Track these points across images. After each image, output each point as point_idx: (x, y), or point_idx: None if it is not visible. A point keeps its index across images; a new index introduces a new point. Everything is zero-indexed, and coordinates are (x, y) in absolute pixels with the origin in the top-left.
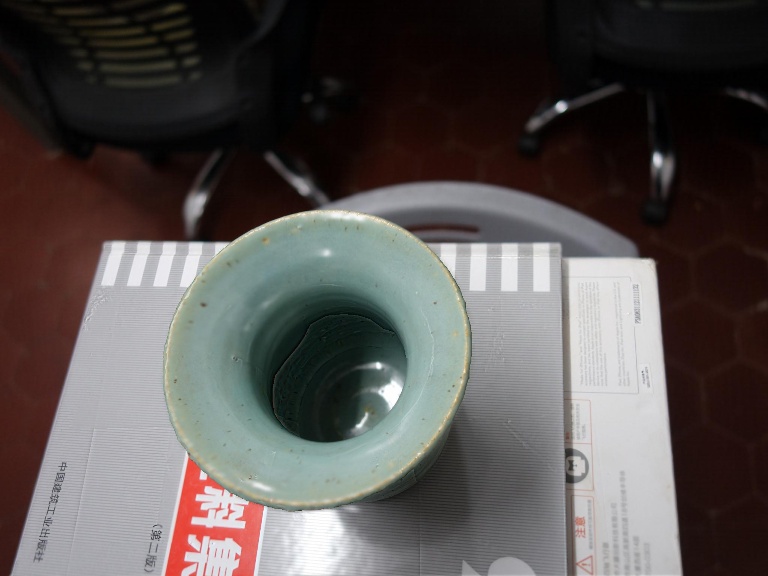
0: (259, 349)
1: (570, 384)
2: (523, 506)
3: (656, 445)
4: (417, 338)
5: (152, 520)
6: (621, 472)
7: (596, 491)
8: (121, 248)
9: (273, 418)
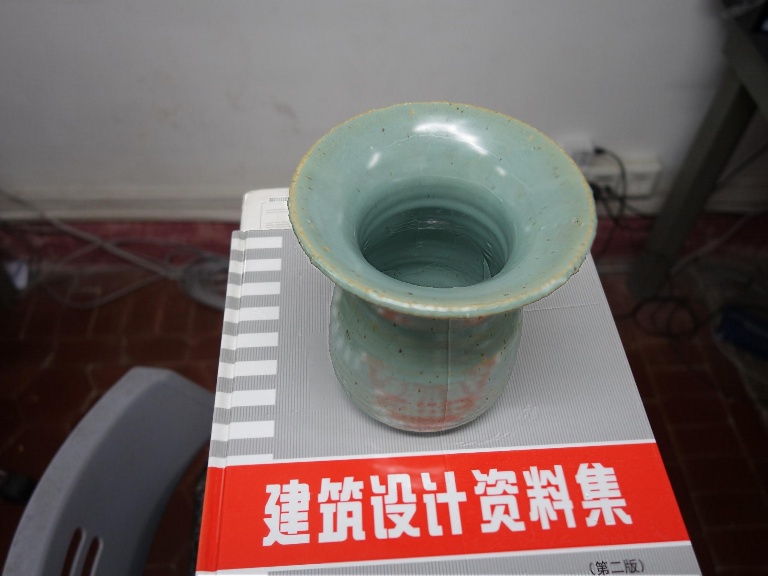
0: None
1: None
2: None
3: None
4: (409, 156)
5: None
6: None
7: None
8: None
9: None
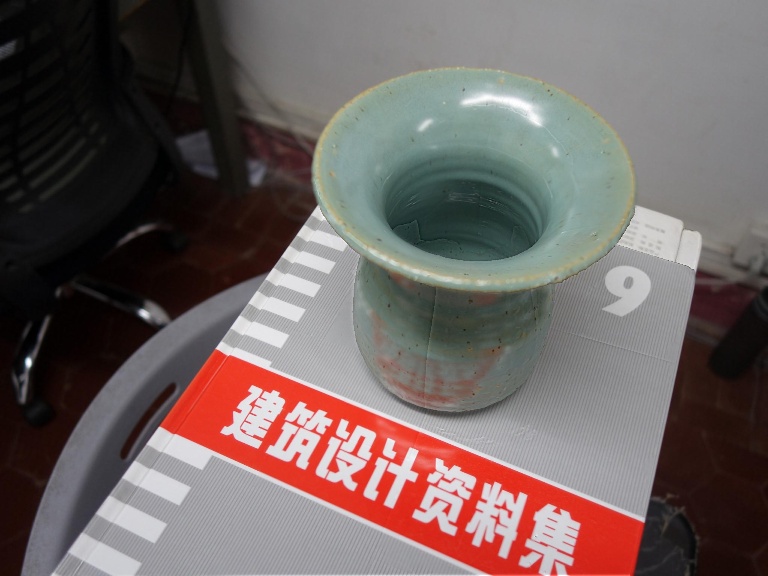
0: None
1: None
2: None
3: None
4: (481, 124)
5: None
6: None
7: None
8: None
9: None
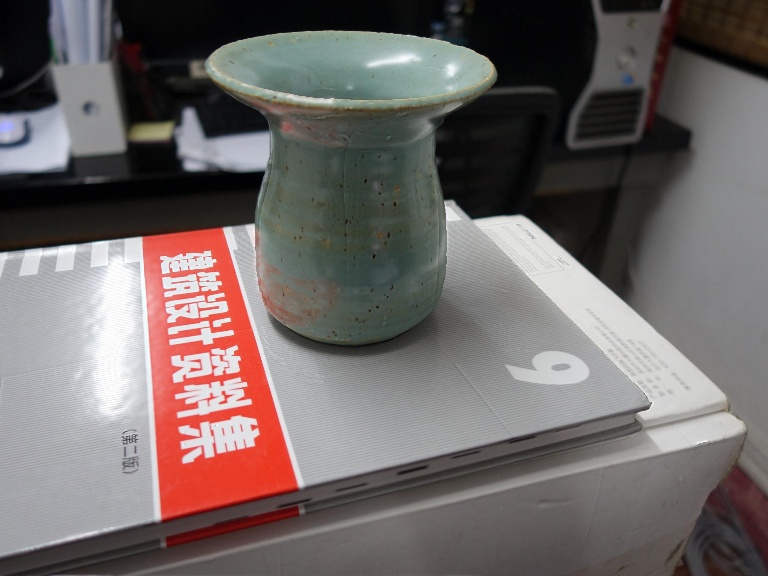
0: None
1: None
2: (531, 322)
3: (599, 291)
4: (428, 83)
5: (119, 428)
6: (587, 309)
7: (577, 323)
8: (3, 256)
9: None
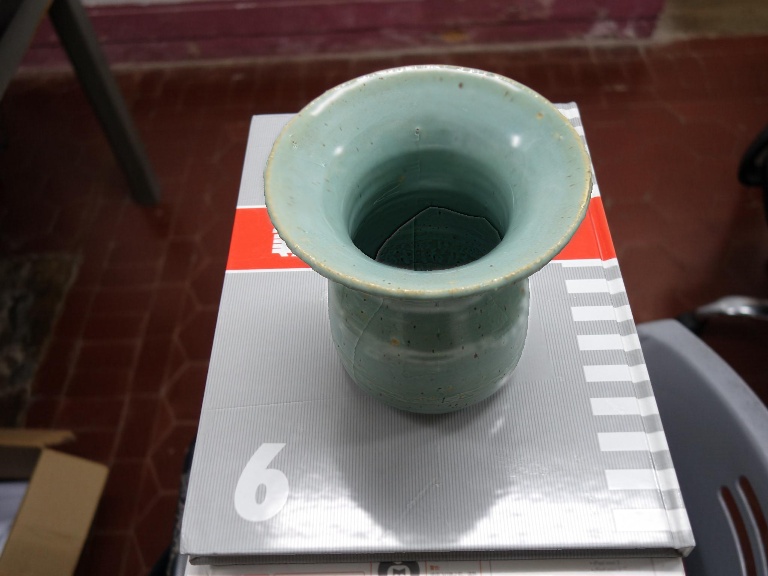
0: (438, 160)
1: (501, 571)
2: (342, 503)
3: None
4: None
5: None
6: None
7: None
8: (572, 116)
9: (371, 183)
